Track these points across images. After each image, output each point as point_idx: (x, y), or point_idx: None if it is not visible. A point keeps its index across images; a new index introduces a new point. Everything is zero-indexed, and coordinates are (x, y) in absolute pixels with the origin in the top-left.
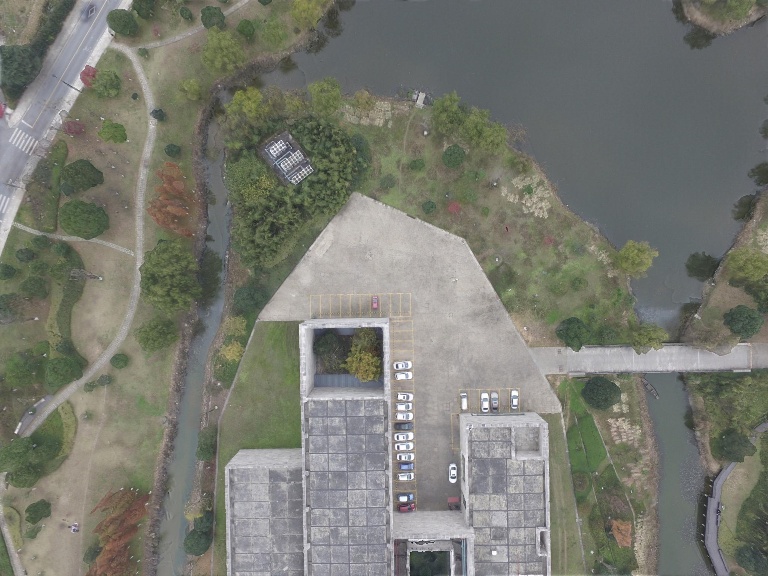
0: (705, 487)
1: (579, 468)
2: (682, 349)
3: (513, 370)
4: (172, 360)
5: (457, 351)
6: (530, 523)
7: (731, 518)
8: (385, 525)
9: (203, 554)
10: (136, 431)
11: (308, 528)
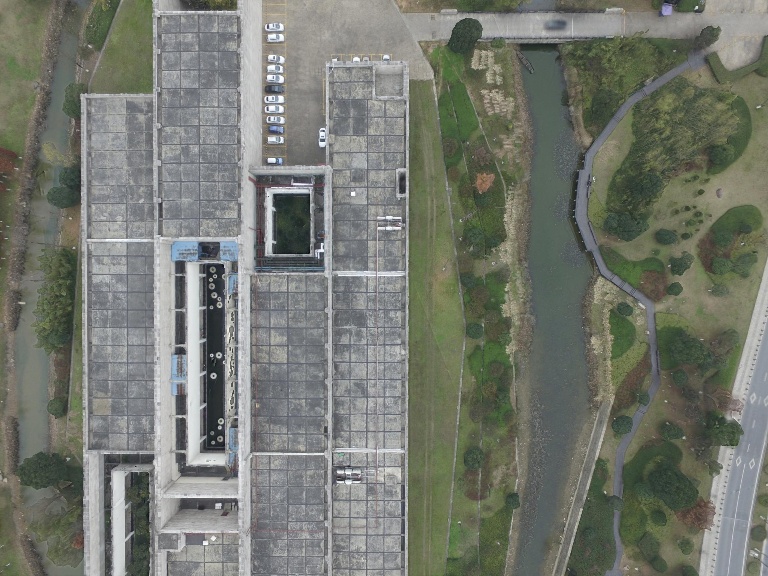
0: (578, 163)
1: (449, 134)
2: (556, 16)
3: (386, 36)
4: (45, 25)
5: (330, 16)
6: (390, 165)
7: (602, 191)
8: (236, 144)
9: (71, 218)
10: (6, 93)
11: (159, 147)
